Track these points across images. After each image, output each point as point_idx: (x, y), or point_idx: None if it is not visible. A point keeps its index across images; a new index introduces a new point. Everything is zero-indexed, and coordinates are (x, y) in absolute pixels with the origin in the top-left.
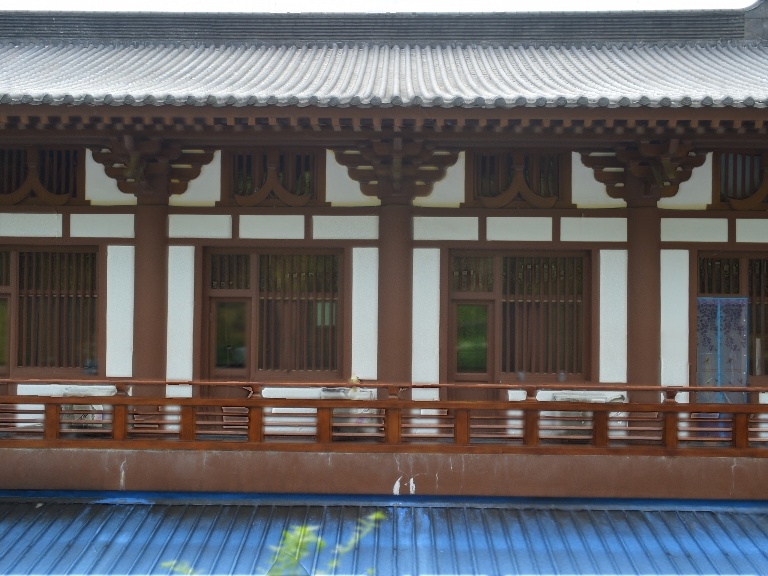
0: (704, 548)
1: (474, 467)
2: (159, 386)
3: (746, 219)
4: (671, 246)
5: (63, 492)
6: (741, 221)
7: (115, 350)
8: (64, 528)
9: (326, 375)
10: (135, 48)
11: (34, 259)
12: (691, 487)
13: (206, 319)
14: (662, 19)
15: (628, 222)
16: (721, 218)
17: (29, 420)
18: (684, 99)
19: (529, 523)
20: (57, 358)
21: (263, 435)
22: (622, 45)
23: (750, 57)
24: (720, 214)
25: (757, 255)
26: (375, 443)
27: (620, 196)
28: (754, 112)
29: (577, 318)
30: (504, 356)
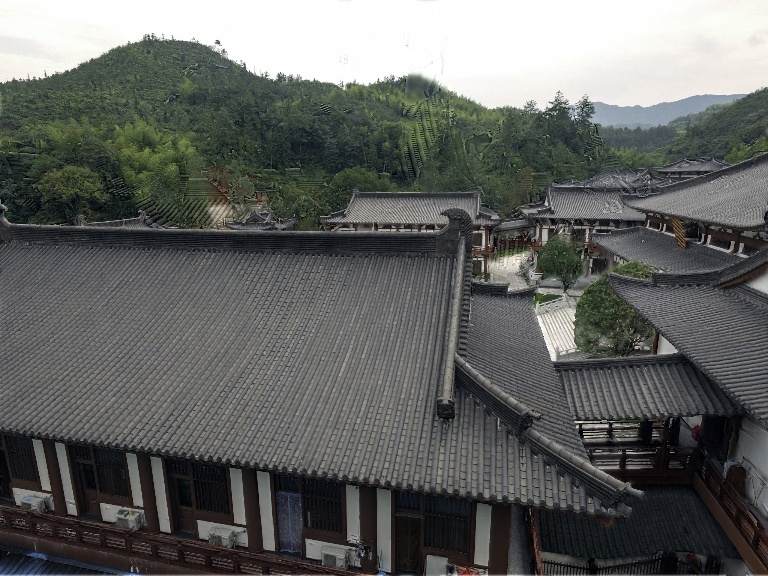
0: None
1: (159, 568)
2: (62, 497)
3: None
4: (261, 470)
5: (17, 548)
6: None
7: (43, 481)
8: (7, 573)
9: (126, 500)
10: (110, 249)
11: (10, 437)
12: None
13: (76, 471)
14: (386, 239)
15: None
16: None
17: (1, 520)
18: (200, 456)
19: None
20: (26, 477)
21: (82, 540)
22: (362, 255)
23: (428, 273)
24: None
25: None
26: (122, 551)
27: None
28: None
29: (226, 492)
30: (197, 503)
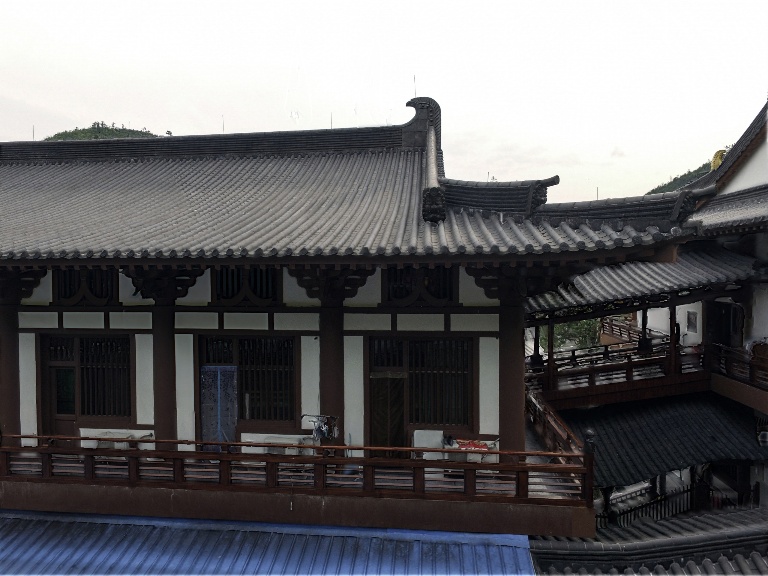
0: (104, 561)
1: (9, 490)
2: None
3: (231, 313)
4: (181, 332)
5: None
6: (227, 314)
7: None
8: None
9: None
10: (10, 166)
11: None
12: (145, 508)
13: None
14: (346, 135)
15: (153, 315)
16: (214, 312)
17: None
18: (89, 252)
19: (25, 533)
20: None
21: None
22: (318, 154)
23: (395, 162)
24: (214, 309)
25: (243, 337)
26: None
27: (150, 297)
28: (137, 260)
29: (129, 379)
30: (83, 404)
